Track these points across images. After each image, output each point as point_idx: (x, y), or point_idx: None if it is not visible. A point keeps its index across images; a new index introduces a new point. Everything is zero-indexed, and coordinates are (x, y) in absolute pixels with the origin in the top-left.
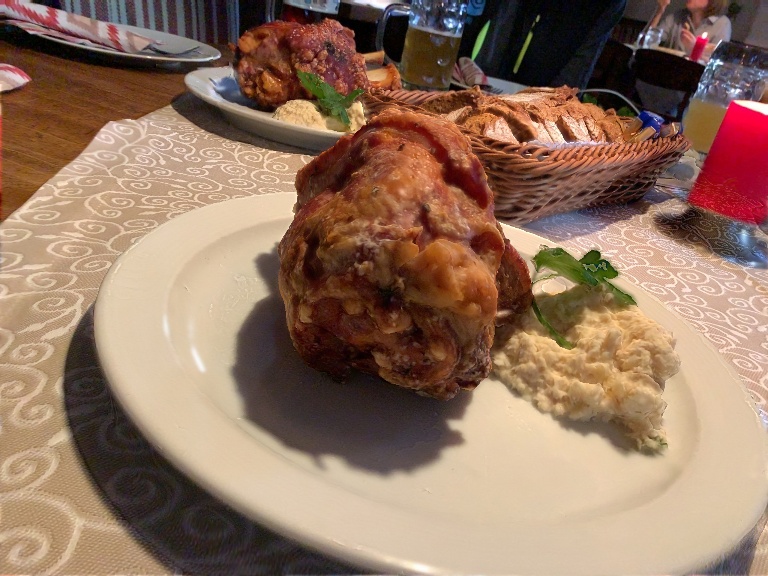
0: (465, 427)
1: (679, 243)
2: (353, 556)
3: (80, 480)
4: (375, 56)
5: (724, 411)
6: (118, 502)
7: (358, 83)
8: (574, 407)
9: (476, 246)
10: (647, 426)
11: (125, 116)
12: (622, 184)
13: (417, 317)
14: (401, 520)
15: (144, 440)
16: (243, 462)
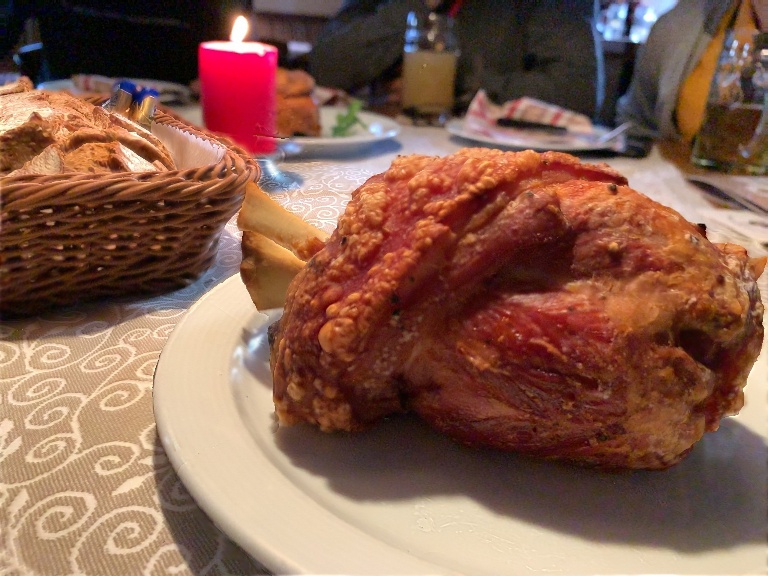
0: None
1: None
2: None
3: None
4: None
5: None
6: None
7: None
8: None
9: None
10: None
11: None
12: None
13: None
14: None
15: None
16: None
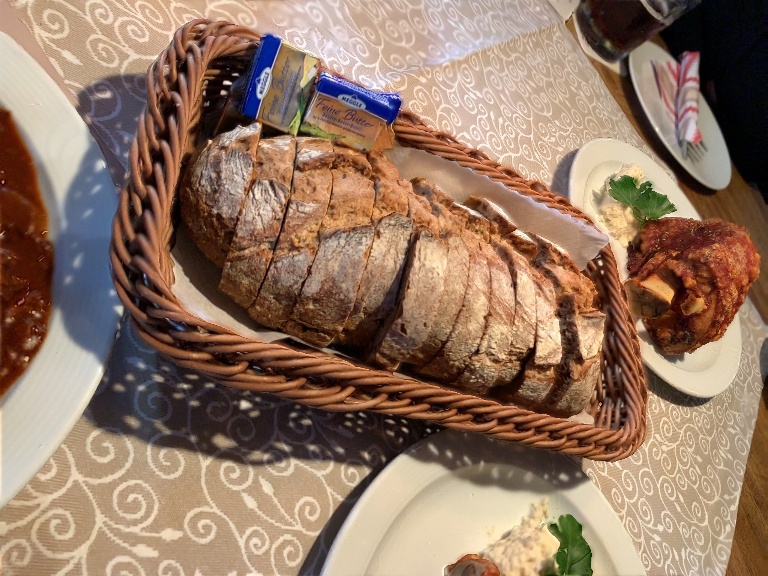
0: None
1: None
2: None
3: None
4: None
5: None
6: None
7: None
8: None
9: None
10: None
11: None
12: None
13: None
14: None
15: None
16: None
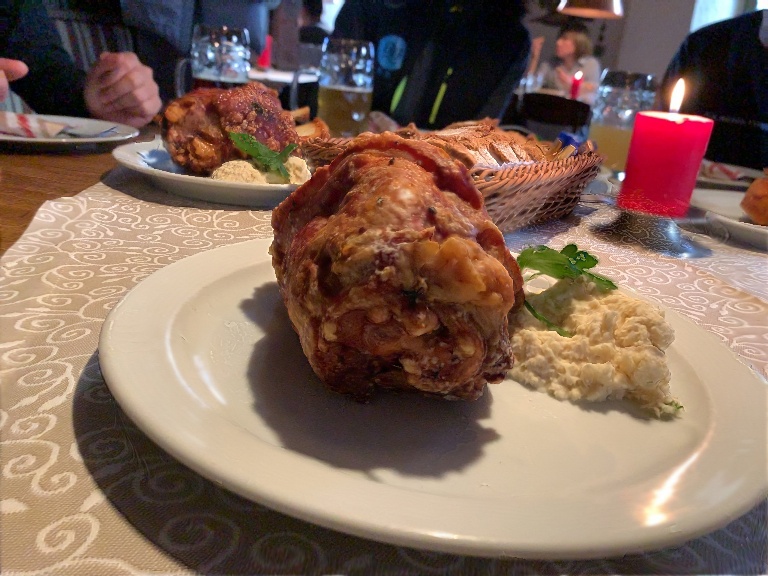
0: (496, 424)
1: (617, 246)
2: (453, 546)
3: (128, 539)
4: (300, 113)
5: (721, 370)
6: (177, 553)
7: (289, 139)
8: (589, 389)
9: (480, 244)
10: (660, 394)
11: (57, 197)
12: (554, 200)
13: (442, 315)
14: (482, 507)
15: (199, 478)
16: (307, 482)
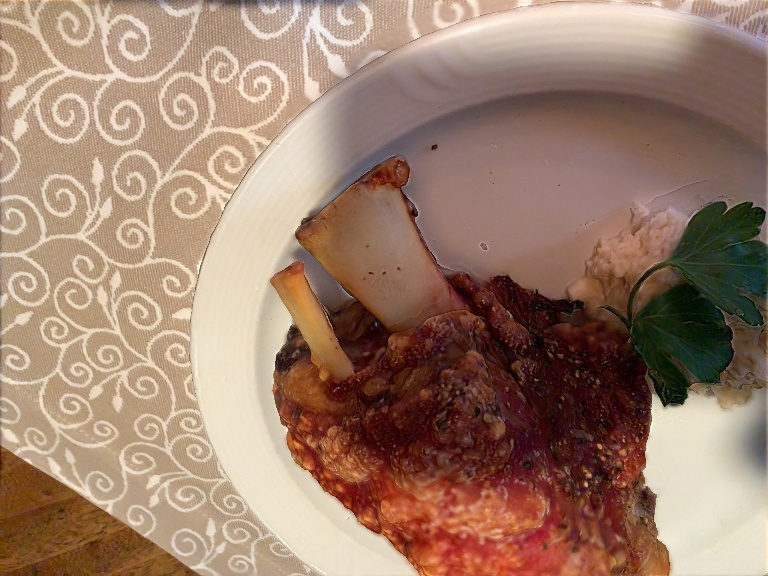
0: None
1: None
2: None
3: None
4: None
5: None
6: None
7: None
8: None
9: None
10: None
11: None
12: None
13: None
14: None
15: None
16: None
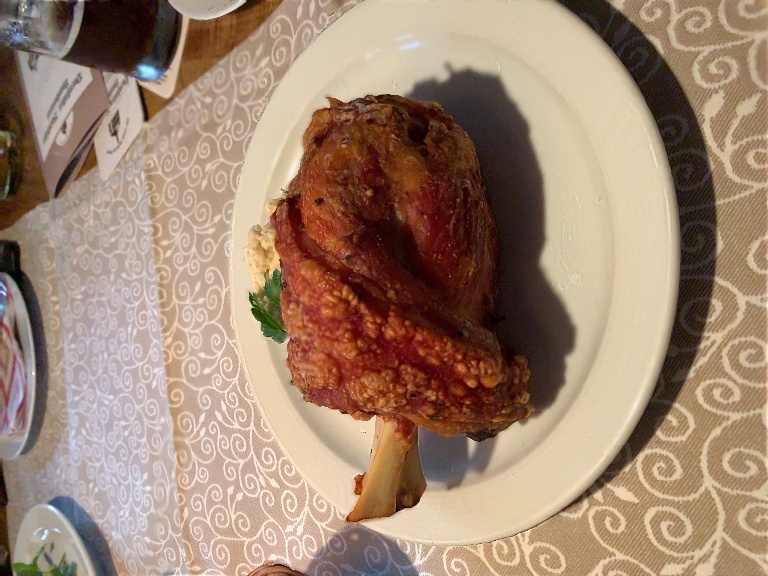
0: None
1: None
2: None
3: None
4: None
5: (246, 228)
6: None
7: None
8: None
9: None
10: None
11: None
12: None
13: None
14: (389, 21)
15: None
16: (467, 6)
